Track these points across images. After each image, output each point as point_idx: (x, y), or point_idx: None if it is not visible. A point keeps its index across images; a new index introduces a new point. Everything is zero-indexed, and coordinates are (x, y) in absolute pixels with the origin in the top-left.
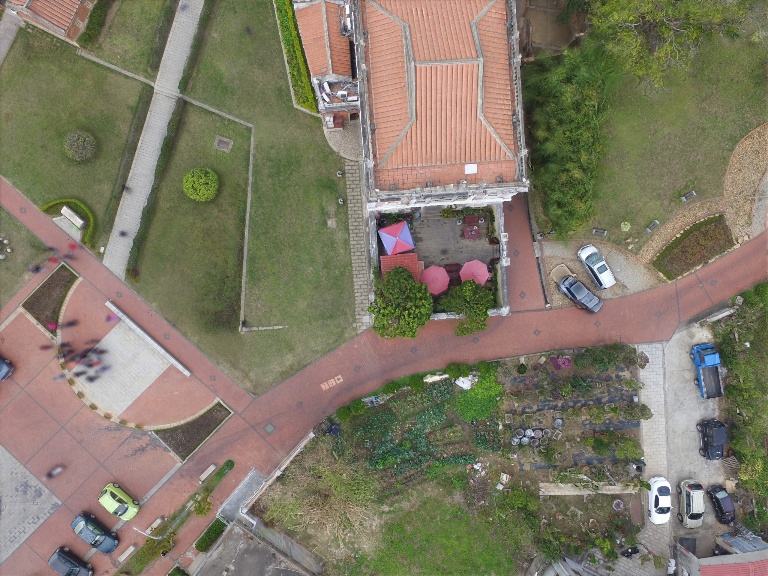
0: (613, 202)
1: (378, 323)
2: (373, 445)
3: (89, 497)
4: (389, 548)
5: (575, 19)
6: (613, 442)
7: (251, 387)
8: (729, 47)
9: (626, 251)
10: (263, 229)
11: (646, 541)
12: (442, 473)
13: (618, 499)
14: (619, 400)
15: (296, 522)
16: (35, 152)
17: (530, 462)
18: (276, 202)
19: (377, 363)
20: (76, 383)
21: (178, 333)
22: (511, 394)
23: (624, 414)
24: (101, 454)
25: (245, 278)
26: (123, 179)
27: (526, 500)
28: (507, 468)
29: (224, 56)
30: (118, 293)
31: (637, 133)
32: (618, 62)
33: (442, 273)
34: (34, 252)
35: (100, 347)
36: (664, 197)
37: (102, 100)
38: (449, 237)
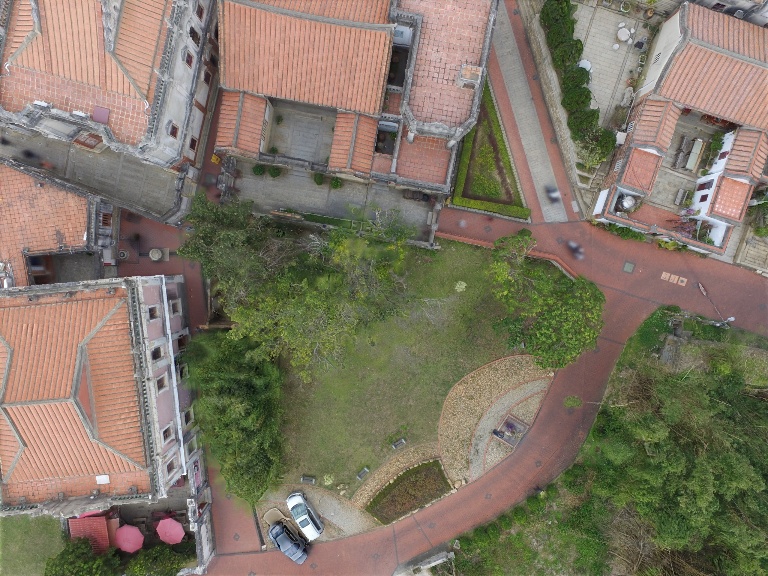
0: (322, 448)
1: None
2: None
3: None
4: None
5: None
6: None
7: None
8: (439, 290)
9: (339, 496)
10: None
11: None
12: None
13: None
14: None
15: None
16: None
17: None
18: None
19: None
20: None
21: None
22: None
23: None
24: None
25: None
26: None
27: None
28: None
29: None
30: None
31: (344, 379)
32: None
33: (135, 533)
34: None
35: None
36: (375, 443)
37: None
38: None
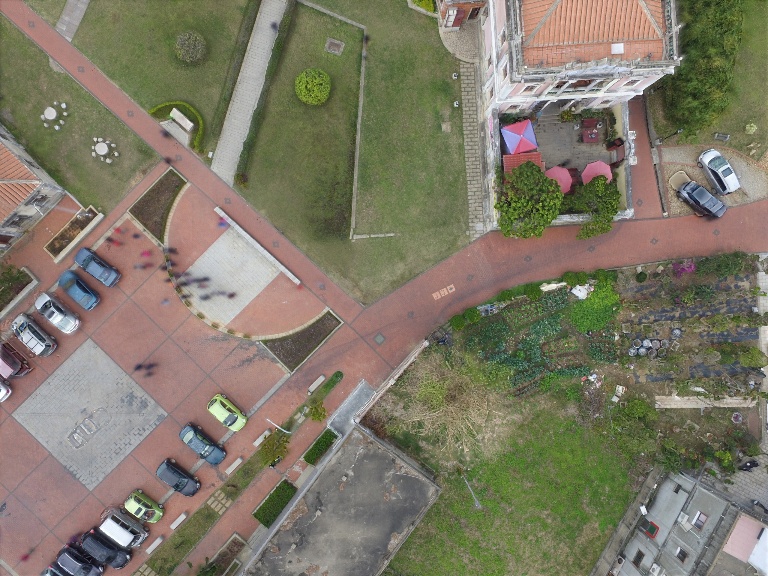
0: (735, 106)
1: (506, 220)
2: (486, 356)
3: (196, 408)
4: (501, 461)
5: None
6: (736, 351)
7: (361, 297)
8: None
9: (747, 157)
10: (375, 133)
11: (763, 456)
12: (556, 385)
13: (737, 412)
14: (738, 311)
15: (408, 434)
16: (142, 54)
17: (646, 374)
18: (389, 105)
19: (491, 272)
20: (183, 291)
21: (287, 241)
22: None
23: (747, 322)
24: (208, 365)
25: (356, 184)
26: (233, 81)
27: (646, 410)
28: (622, 380)
29: None
30: (226, 199)
31: (761, 34)
32: None
33: (565, 174)
34: (141, 157)
35: (208, 254)
36: None
37: (211, 0)
38: (565, 142)
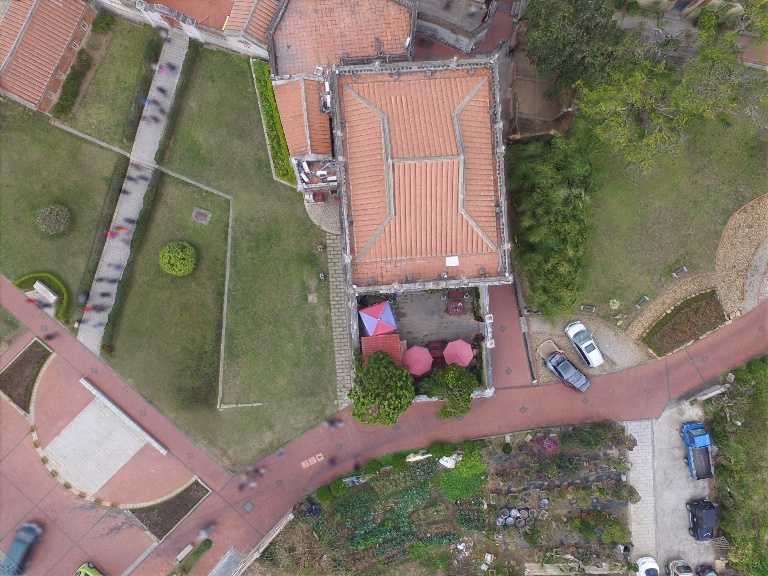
0: (602, 277)
1: (358, 410)
2: (355, 525)
3: None
4: None
5: (563, 91)
6: (600, 525)
7: (230, 465)
8: None
9: (615, 327)
10: (242, 304)
11: None
12: (425, 553)
13: None
14: (607, 479)
15: None
16: (7, 224)
17: (515, 542)
18: (255, 276)
19: (359, 441)
20: (50, 461)
21: (155, 409)
22: (496, 474)
23: (612, 496)
24: (76, 533)
25: (223, 354)
26: (98, 252)
27: None
28: (492, 548)
29: (202, 126)
30: (93, 369)
31: (627, 207)
32: (606, 145)
33: (425, 354)
34: (6, 327)
35: (74, 424)
36: (654, 272)
37: (76, 170)
38: (433, 312)
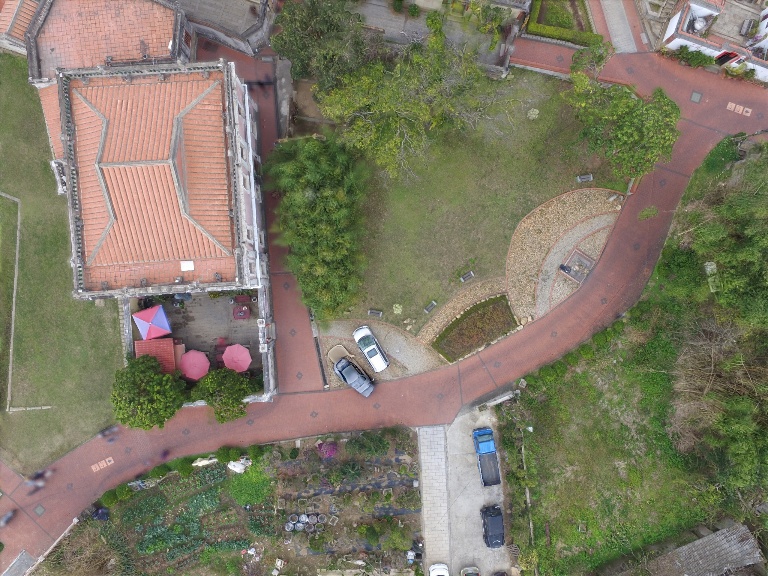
0: (390, 282)
1: None
2: (145, 529)
3: None
4: None
5: None
6: (384, 531)
7: (21, 468)
8: None
9: (405, 332)
10: (30, 307)
11: None
12: (216, 558)
13: None
14: (399, 484)
15: None
16: None
17: (307, 547)
18: (43, 279)
19: (149, 445)
20: None
21: None
22: (283, 479)
23: None
24: None
25: (12, 357)
26: None
27: None
28: (283, 553)
29: None
30: None
31: (414, 211)
32: None
33: (201, 358)
34: None
35: None
36: (443, 277)
37: None
38: (222, 316)
